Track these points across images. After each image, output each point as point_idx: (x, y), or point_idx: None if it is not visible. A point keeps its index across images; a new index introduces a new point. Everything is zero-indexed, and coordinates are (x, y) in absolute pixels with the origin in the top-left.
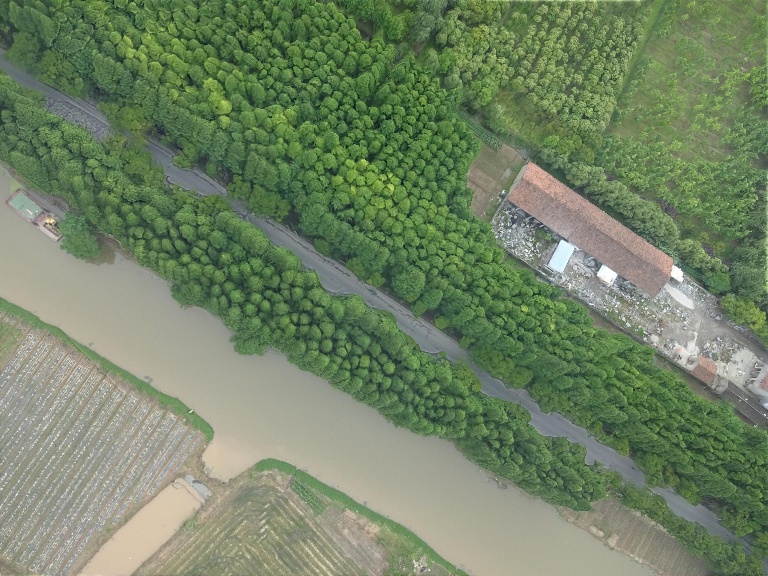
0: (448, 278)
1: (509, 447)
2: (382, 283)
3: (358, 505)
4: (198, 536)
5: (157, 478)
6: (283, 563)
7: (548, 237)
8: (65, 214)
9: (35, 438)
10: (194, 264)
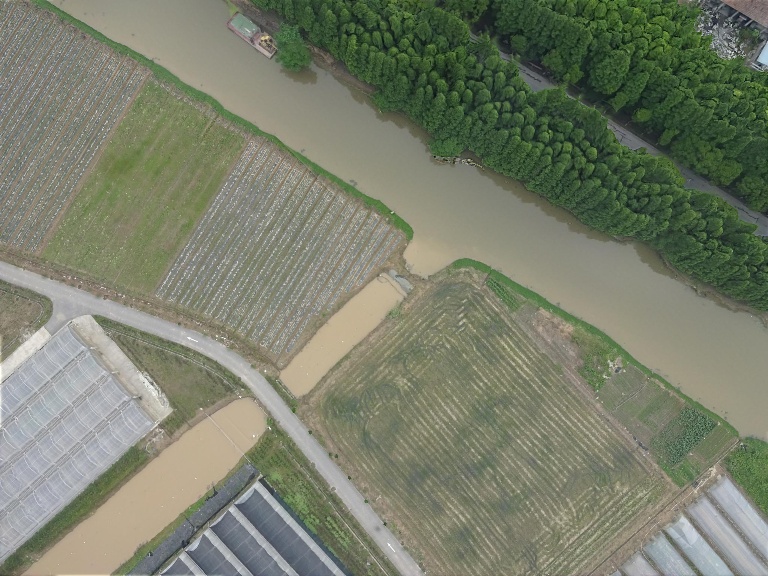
0: (654, 61)
1: (716, 240)
2: (580, 77)
3: (552, 305)
4: (402, 325)
5: (364, 271)
6: (481, 354)
7: (756, 33)
8: (281, 25)
9: (260, 232)
10: (403, 53)
